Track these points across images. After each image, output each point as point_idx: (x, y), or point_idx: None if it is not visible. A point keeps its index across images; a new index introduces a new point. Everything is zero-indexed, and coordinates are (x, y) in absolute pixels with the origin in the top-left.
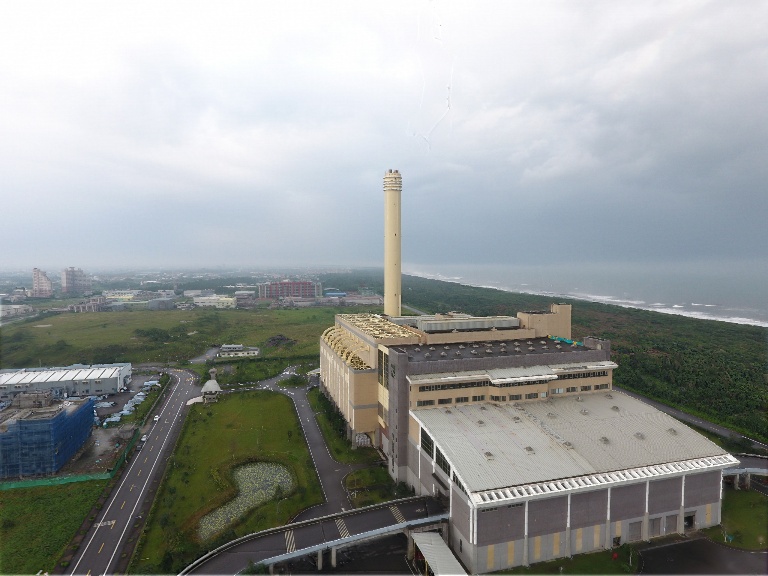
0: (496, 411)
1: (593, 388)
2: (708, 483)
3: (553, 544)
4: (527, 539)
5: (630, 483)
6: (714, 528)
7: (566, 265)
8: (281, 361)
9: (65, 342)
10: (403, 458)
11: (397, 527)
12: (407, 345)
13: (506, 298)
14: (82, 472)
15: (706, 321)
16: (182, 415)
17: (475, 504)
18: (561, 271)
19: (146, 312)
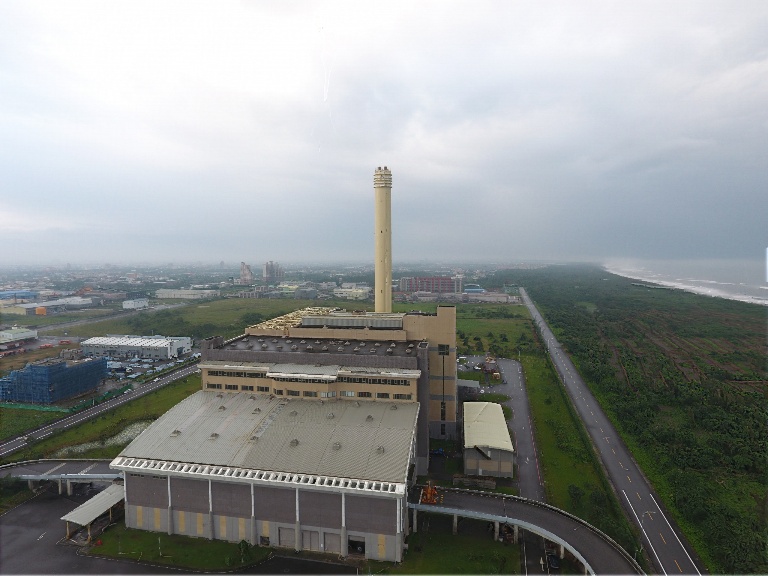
0: (259, 402)
1: (391, 397)
2: (379, 510)
3: (197, 523)
4: (169, 510)
5: (259, 483)
6: (383, 562)
7: None
8: None
9: (191, 319)
10: None
11: (110, 477)
12: (271, 336)
13: (682, 302)
14: (64, 406)
15: None
16: None
17: None
18: None
19: (284, 300)
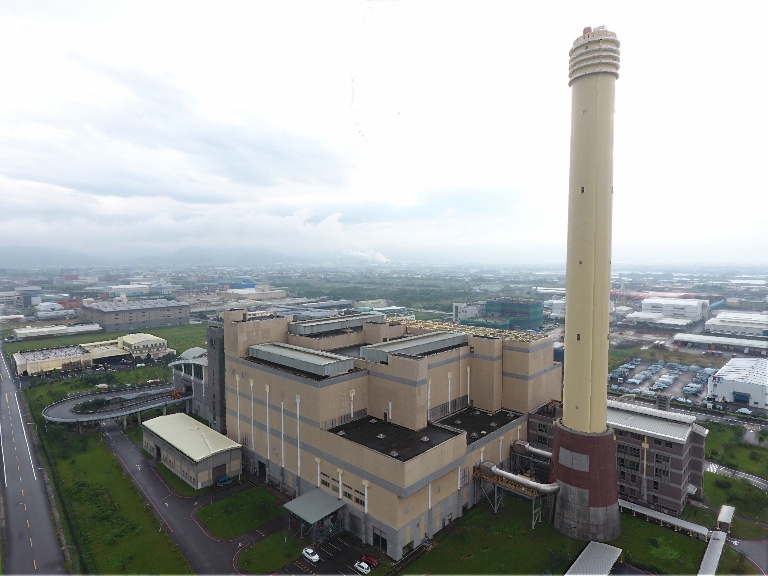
0: None
1: None
2: None
3: None
4: None
5: None
6: None
7: None
8: None
9: None
10: None
11: None
12: None
13: None
14: None
15: None
16: None
17: None
18: None
19: None
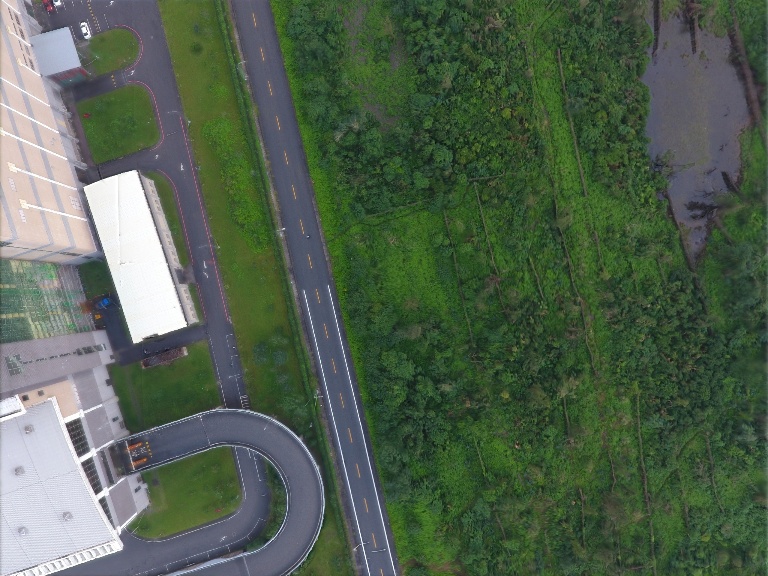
0: None
1: None
2: None
3: None
4: None
5: None
6: None
7: None
8: None
9: None
10: None
11: None
12: None
13: None
14: None
15: None
16: None
17: None
18: None
19: None
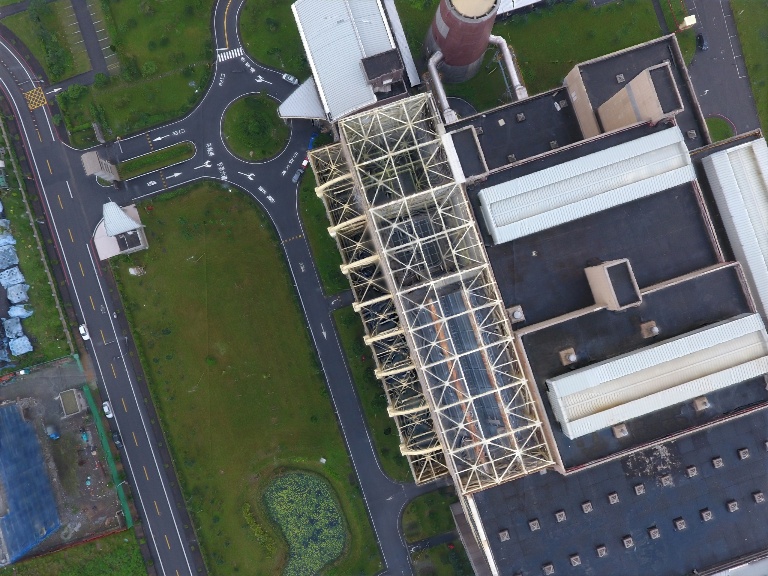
0: None
1: None
2: None
3: None
4: None
5: None
6: None
7: None
8: (197, 2)
9: None
10: None
11: None
12: None
13: None
14: (88, 511)
15: None
16: (117, 314)
17: None
18: None
19: None
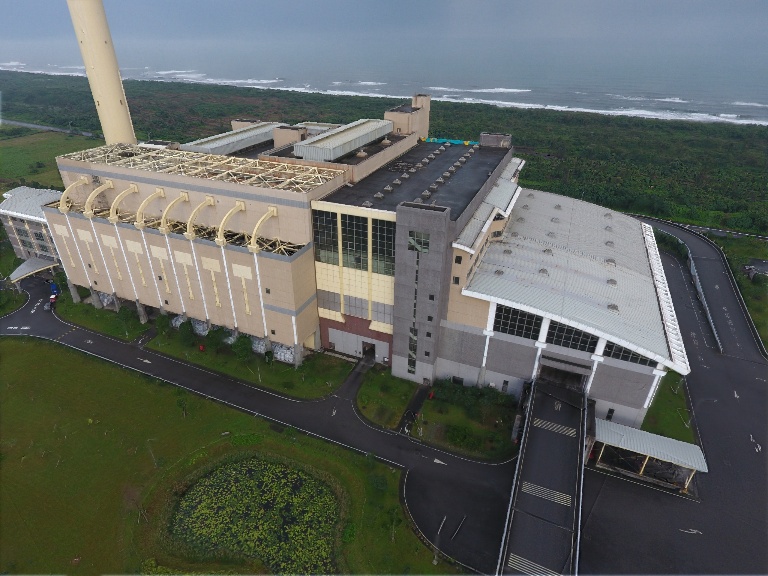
0: (518, 250)
1: None
2: None
3: None
4: None
5: None
6: None
7: (168, 39)
8: None
9: None
10: (436, 352)
11: None
12: (338, 191)
13: None
14: None
15: (346, 97)
16: None
17: (686, 372)
18: (164, 47)
19: None
